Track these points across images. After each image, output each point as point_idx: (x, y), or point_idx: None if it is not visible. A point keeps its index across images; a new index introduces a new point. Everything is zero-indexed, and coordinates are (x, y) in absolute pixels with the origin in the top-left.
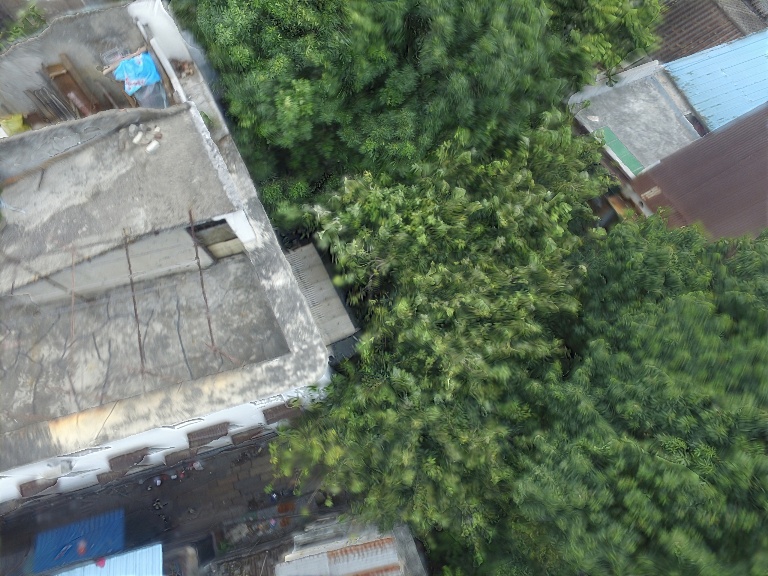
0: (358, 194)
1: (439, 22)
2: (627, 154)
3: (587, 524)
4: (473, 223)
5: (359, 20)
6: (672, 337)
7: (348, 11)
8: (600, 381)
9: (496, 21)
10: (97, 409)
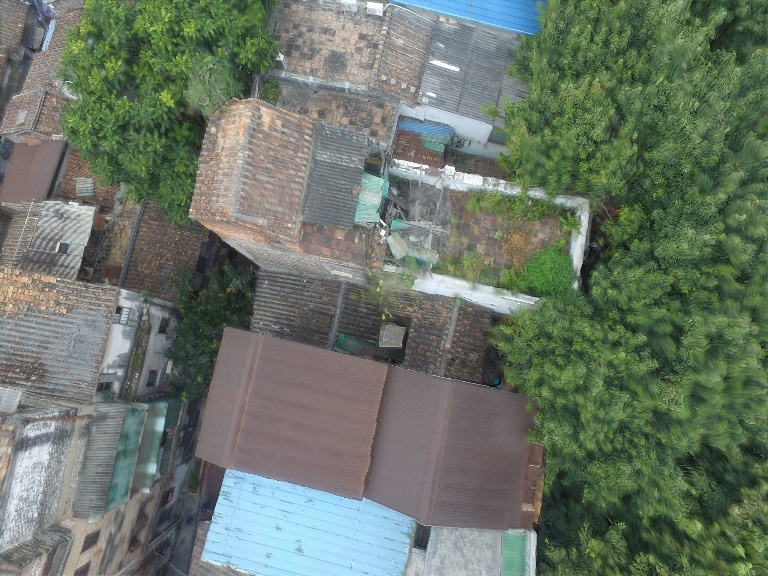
0: None
1: None
2: (508, 552)
3: None
4: None
5: None
6: None
7: None
8: (743, 424)
9: None
10: None
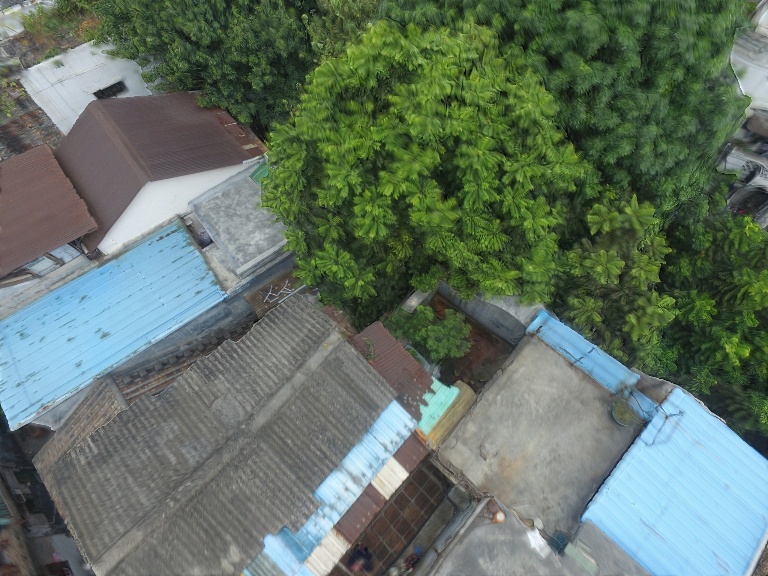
0: None
1: None
2: None
3: None
4: None
5: None
6: None
7: None
8: None
9: None
10: None
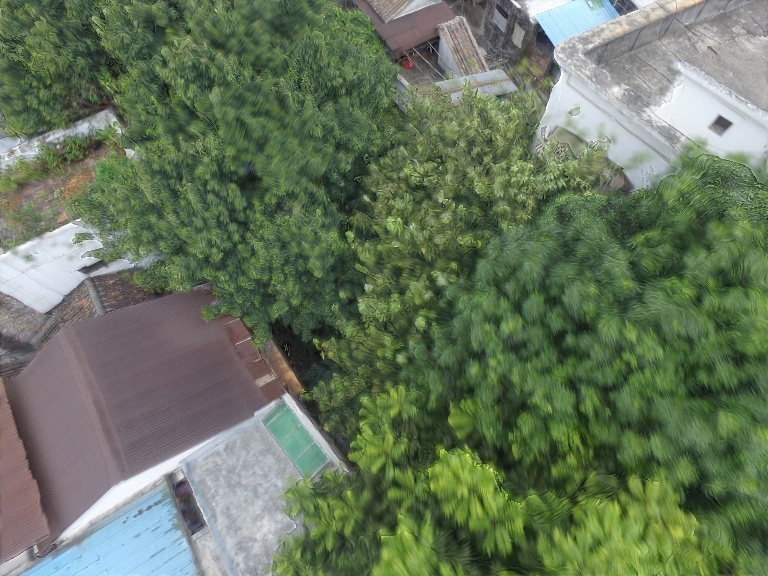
0: (589, 163)
1: (598, 259)
2: (285, 440)
3: (356, 63)
4: (465, 235)
5: (688, 228)
6: (300, 153)
7: (706, 216)
8: (341, 151)
9: (531, 298)
10: (686, 7)
